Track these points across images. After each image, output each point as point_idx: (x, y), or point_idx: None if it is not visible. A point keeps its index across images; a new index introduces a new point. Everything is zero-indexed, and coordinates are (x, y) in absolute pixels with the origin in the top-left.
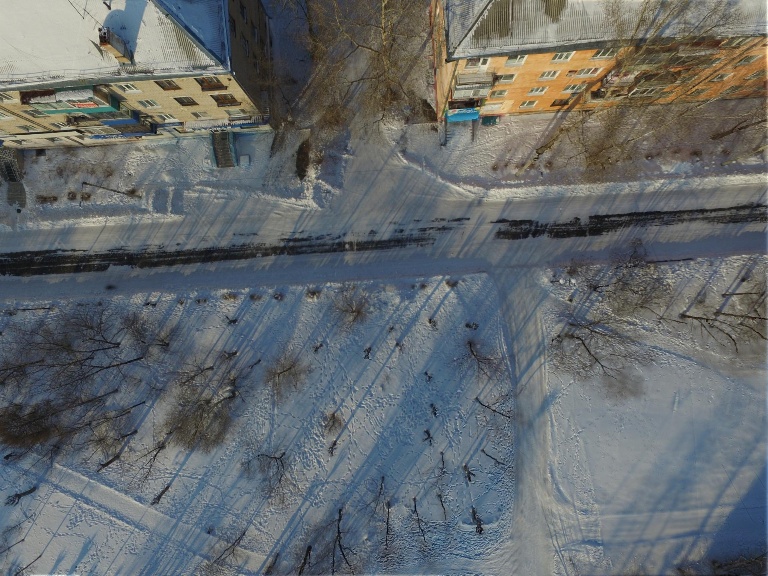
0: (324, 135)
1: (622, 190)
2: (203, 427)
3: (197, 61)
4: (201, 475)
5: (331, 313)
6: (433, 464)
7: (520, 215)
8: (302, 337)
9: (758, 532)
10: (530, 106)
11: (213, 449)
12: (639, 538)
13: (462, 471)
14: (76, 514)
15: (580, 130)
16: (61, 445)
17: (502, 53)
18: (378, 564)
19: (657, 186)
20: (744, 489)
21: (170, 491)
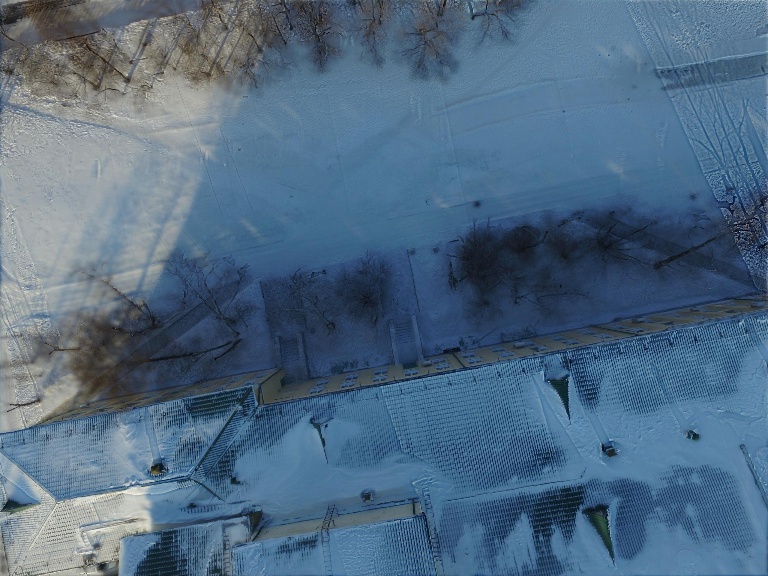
0: None
1: None
2: None
3: None
4: None
5: None
6: None
7: None
8: None
9: None
10: None
11: None
12: (83, 305)
13: None
14: None
15: None
16: None
17: None
18: None
19: None
20: (173, 244)
21: None
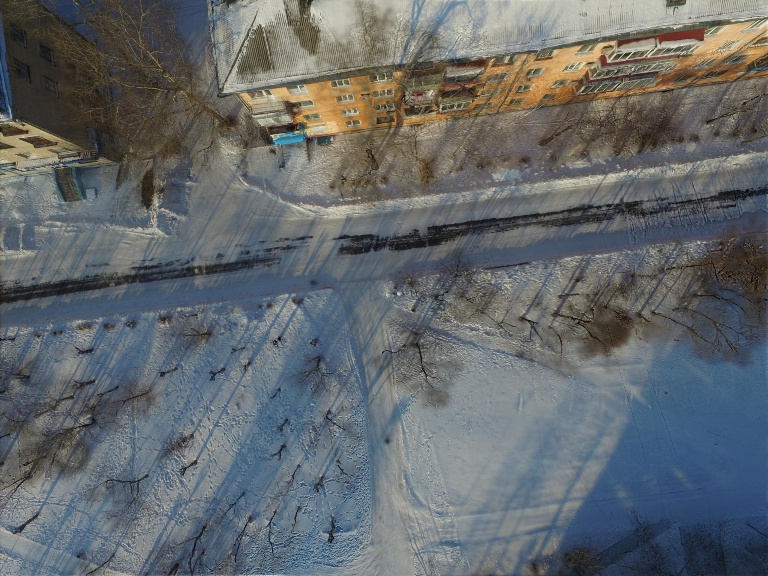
0: (166, 164)
1: (457, 200)
2: (62, 456)
3: None
4: (68, 501)
5: (184, 337)
6: None
7: (361, 230)
8: (157, 362)
9: (607, 523)
10: (358, 125)
11: (77, 476)
12: (494, 536)
13: None
14: None
15: (413, 144)
16: None
17: (269, 86)
18: None
19: (490, 194)
20: (591, 483)
21: (40, 519)
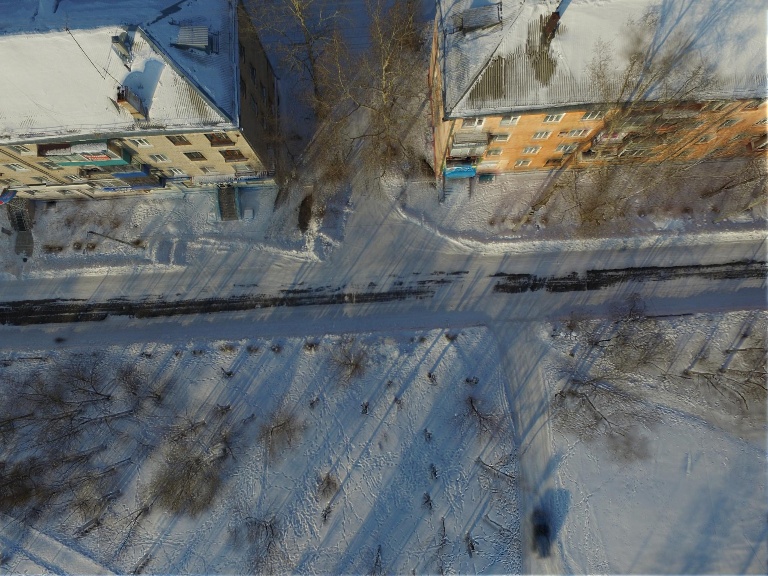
0: (326, 191)
1: (618, 246)
2: (189, 486)
3: (208, 118)
4: (184, 541)
5: (328, 366)
6: (433, 531)
7: (518, 269)
8: (298, 390)
9: None
10: (524, 166)
11: (198, 512)
12: None
13: (465, 539)
14: None
15: (573, 189)
16: (37, 505)
17: (496, 114)
18: None
19: (652, 242)
20: None
21: (149, 559)
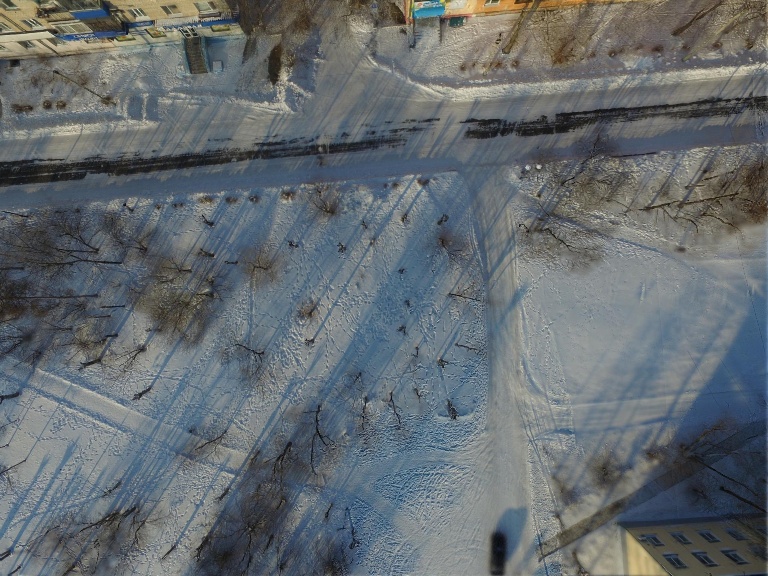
0: (295, 40)
1: (587, 87)
2: (182, 325)
3: None
4: (182, 376)
5: (306, 214)
6: (409, 359)
7: (488, 114)
8: (278, 238)
9: None
10: (495, 4)
11: (193, 349)
12: (610, 425)
13: (437, 365)
14: (59, 418)
15: (545, 30)
16: (43, 350)
17: None
18: (357, 458)
19: (621, 82)
20: (709, 375)
21: (152, 393)
